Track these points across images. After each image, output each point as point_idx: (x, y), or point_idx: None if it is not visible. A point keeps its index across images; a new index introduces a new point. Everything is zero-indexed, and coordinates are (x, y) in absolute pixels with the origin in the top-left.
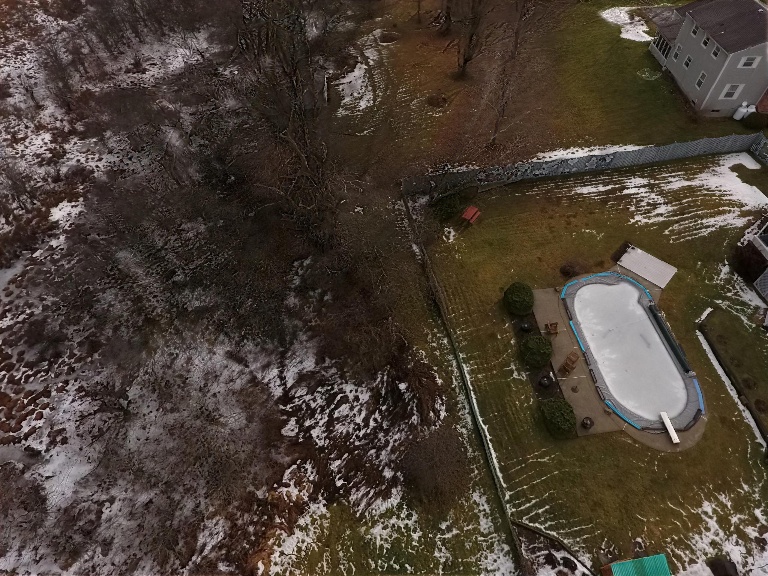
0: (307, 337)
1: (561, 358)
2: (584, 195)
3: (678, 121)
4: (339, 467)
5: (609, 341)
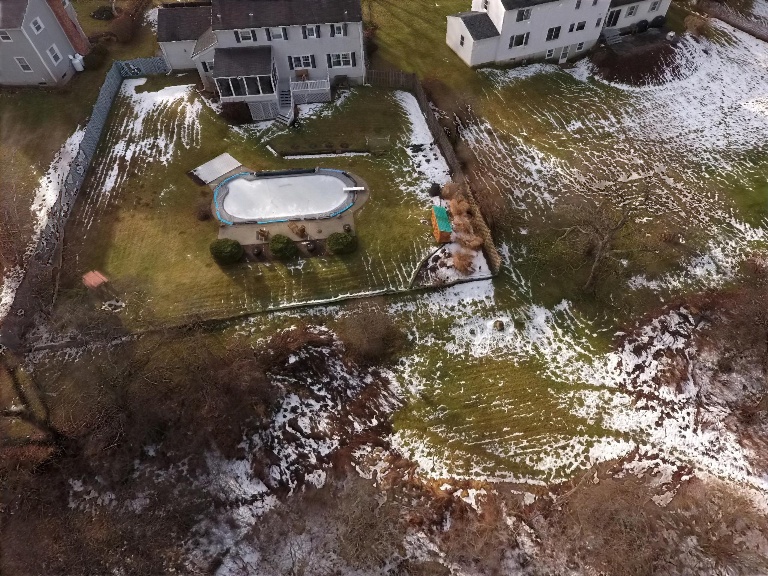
0: (203, 474)
1: (291, 235)
2: (116, 186)
3: (58, 101)
4: (360, 423)
5: (281, 205)
